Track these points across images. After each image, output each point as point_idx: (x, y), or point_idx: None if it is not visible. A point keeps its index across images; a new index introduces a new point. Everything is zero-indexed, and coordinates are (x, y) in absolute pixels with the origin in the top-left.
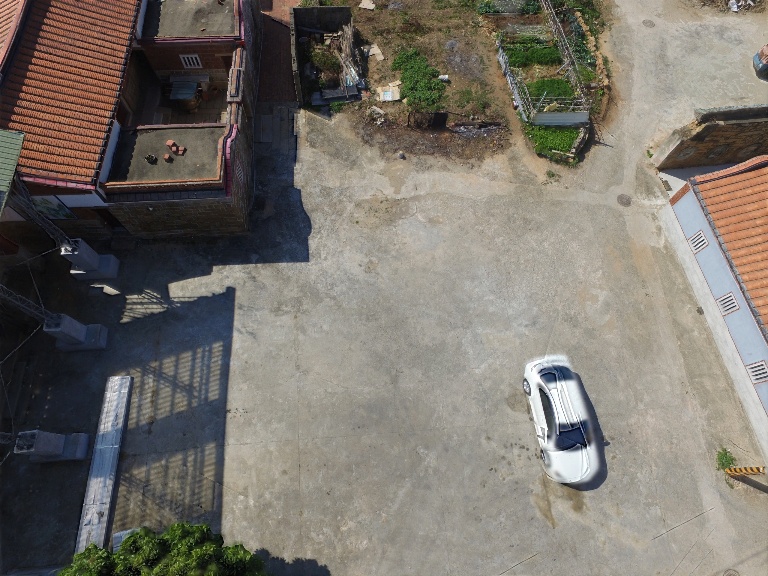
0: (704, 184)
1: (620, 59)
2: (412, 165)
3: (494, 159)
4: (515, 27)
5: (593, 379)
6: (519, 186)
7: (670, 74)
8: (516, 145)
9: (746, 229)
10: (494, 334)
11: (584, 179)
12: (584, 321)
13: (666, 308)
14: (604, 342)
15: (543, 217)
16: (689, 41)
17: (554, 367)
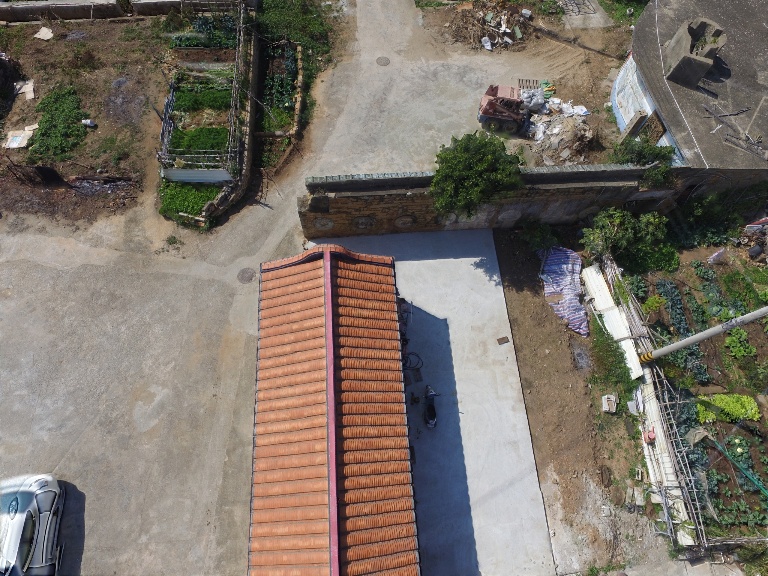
0: (268, 272)
1: (330, 102)
2: (5, 225)
3: (108, 221)
4: (201, 64)
5: (100, 501)
6: (124, 254)
7: (381, 122)
8: (143, 204)
9: (283, 334)
10: (5, 439)
11: (211, 247)
12: (124, 426)
13: (230, 414)
14: (135, 454)
15: (135, 293)
16: (421, 83)
17: (59, 484)
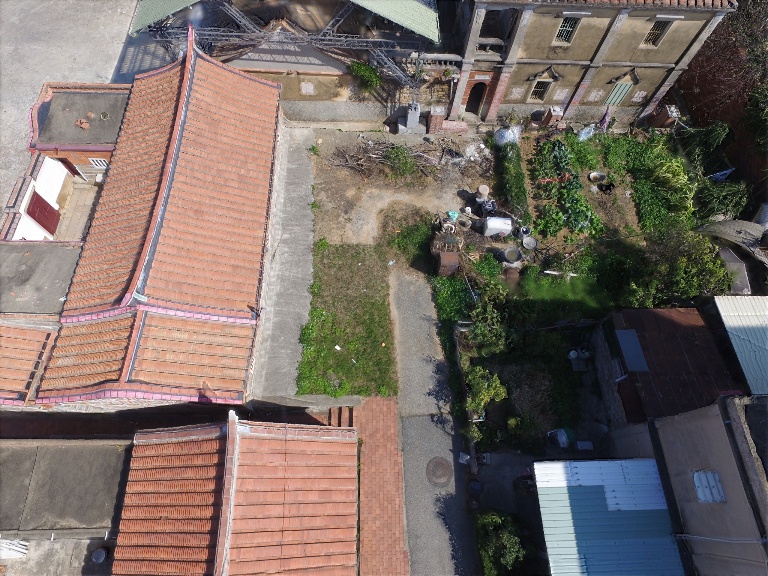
0: None
1: None
2: None
3: None
4: None
5: None
6: None
7: None
8: None
9: None
10: None
11: None
12: None
13: None
14: None
15: None
16: None
17: None
